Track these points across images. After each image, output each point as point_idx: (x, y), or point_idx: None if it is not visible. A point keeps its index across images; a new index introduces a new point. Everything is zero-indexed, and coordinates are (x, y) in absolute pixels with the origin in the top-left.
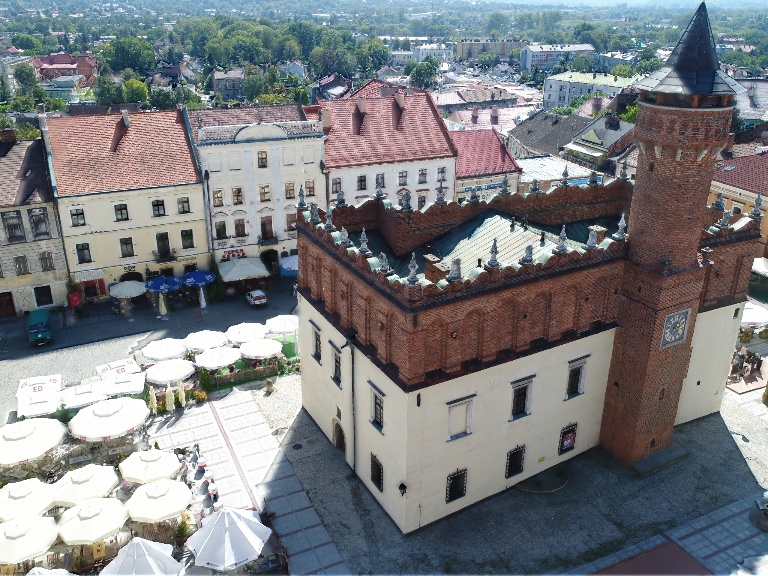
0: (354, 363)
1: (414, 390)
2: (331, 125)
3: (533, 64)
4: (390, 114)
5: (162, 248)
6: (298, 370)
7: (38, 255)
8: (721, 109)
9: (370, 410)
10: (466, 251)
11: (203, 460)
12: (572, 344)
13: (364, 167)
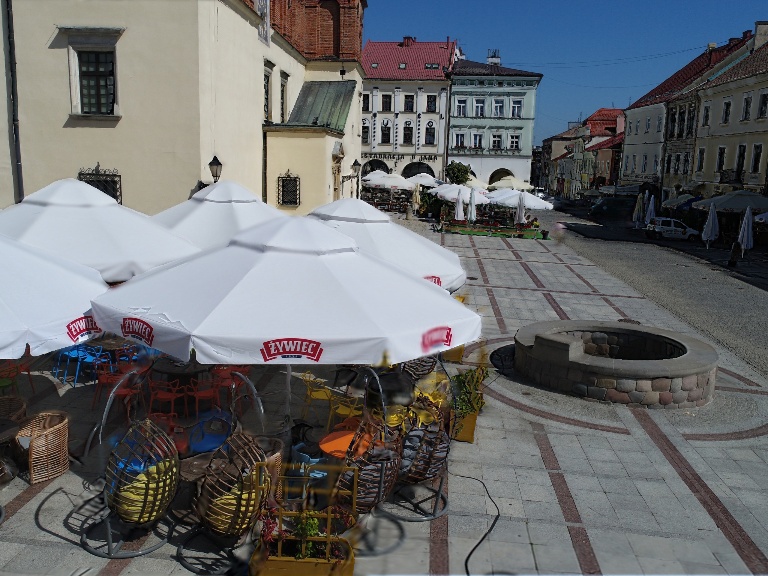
0: None
1: None
2: None
3: None
4: None
5: None
6: None
7: None
8: None
9: None
10: None
11: None
12: None
13: None
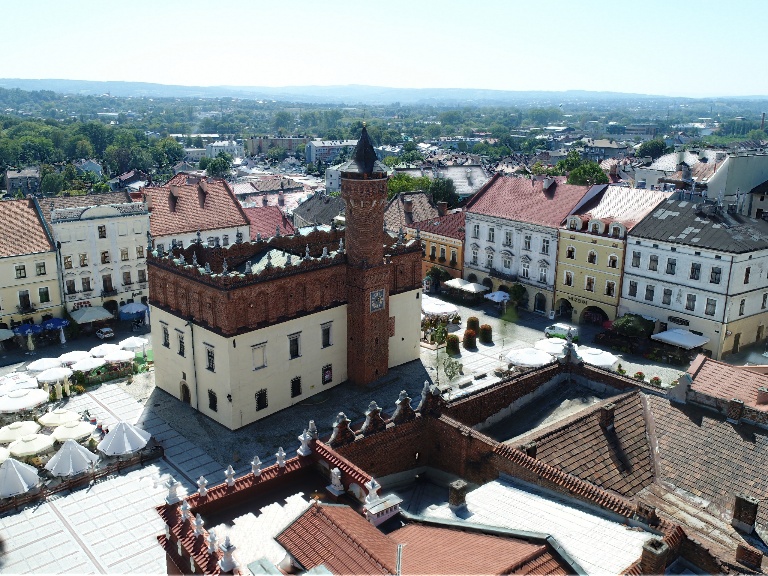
0: (193, 336)
1: (231, 337)
2: (152, 206)
3: (317, 157)
4: (197, 197)
5: (24, 303)
6: (148, 370)
7: None
8: (379, 180)
9: (206, 361)
10: None
11: (94, 416)
12: (322, 314)
13: (181, 235)
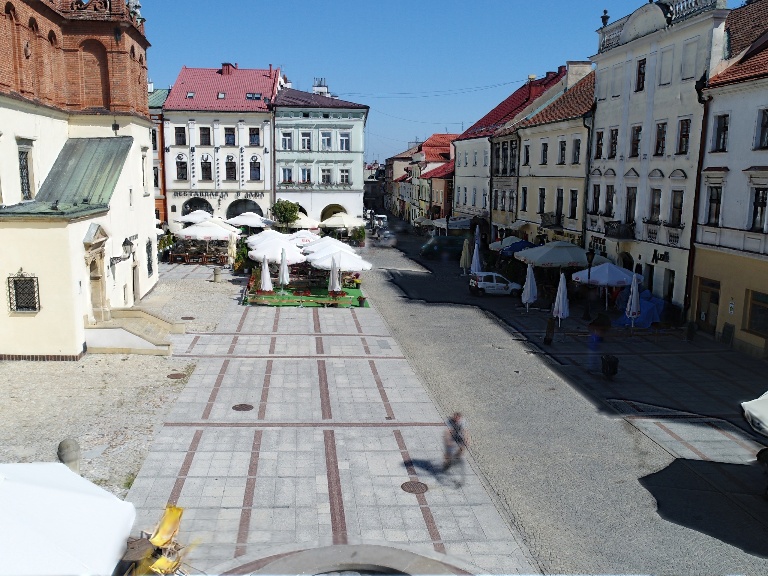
0: None
1: None
2: None
3: None
4: None
5: None
6: None
7: None
8: None
9: None
10: None
11: None
12: None
13: None
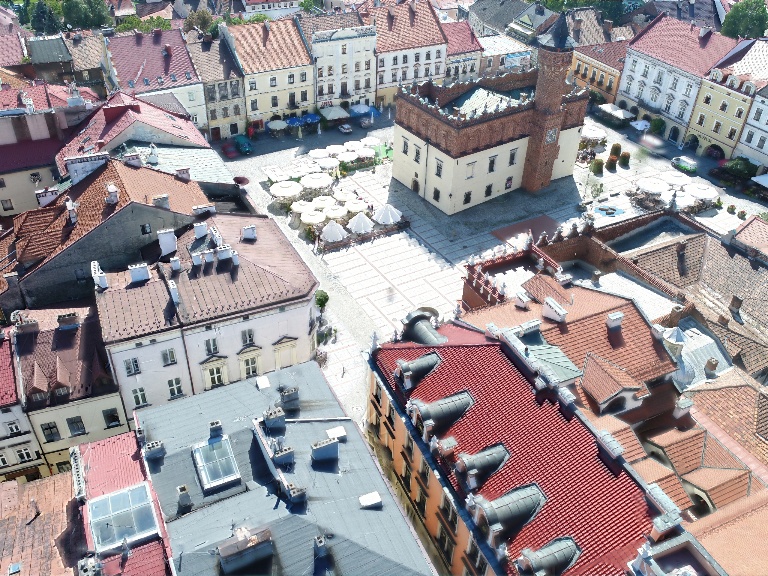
0: (428, 152)
1: (457, 158)
2: None
3: None
4: (408, 16)
5: (291, 101)
6: (383, 163)
7: (233, 106)
8: (568, 52)
9: (435, 170)
10: (469, 105)
11: None
12: (512, 143)
13: (397, 51)
